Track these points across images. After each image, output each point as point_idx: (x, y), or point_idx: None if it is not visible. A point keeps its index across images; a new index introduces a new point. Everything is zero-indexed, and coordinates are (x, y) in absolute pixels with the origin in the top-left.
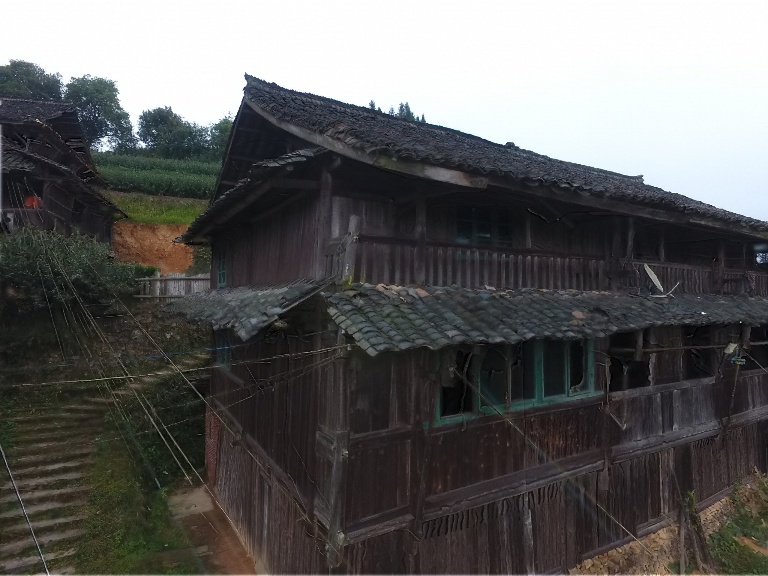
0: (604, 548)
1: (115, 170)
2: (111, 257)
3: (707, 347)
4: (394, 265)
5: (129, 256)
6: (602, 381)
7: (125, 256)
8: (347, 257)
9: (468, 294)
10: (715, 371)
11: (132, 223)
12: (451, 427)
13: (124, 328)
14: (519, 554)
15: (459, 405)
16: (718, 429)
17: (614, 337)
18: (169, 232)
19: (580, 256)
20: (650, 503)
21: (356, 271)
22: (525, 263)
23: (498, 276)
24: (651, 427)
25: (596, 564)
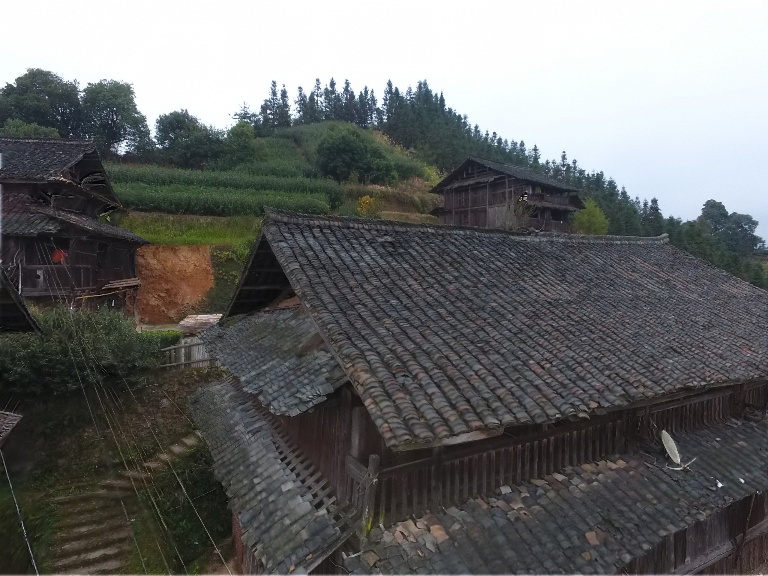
0: None
1: (135, 189)
2: (135, 285)
3: None
4: (412, 490)
5: (152, 278)
6: None
7: (148, 278)
8: (367, 499)
9: (484, 521)
10: None
11: (154, 245)
12: None
13: (152, 398)
14: None
15: None
16: (731, 550)
17: None
18: (190, 253)
19: (597, 424)
20: None
21: (376, 509)
22: (541, 445)
23: (514, 467)
24: (663, 567)
25: None
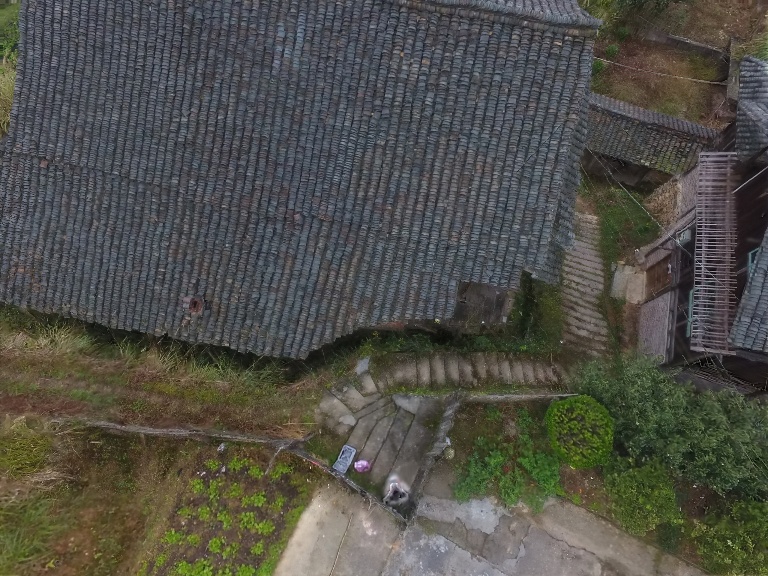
0: None
1: None
2: None
3: None
4: None
5: None
6: None
7: None
8: None
9: None
10: None
11: None
12: None
13: None
14: None
15: None
16: None
17: None
18: None
19: None
20: None
21: None
22: None
23: None
24: None
25: None
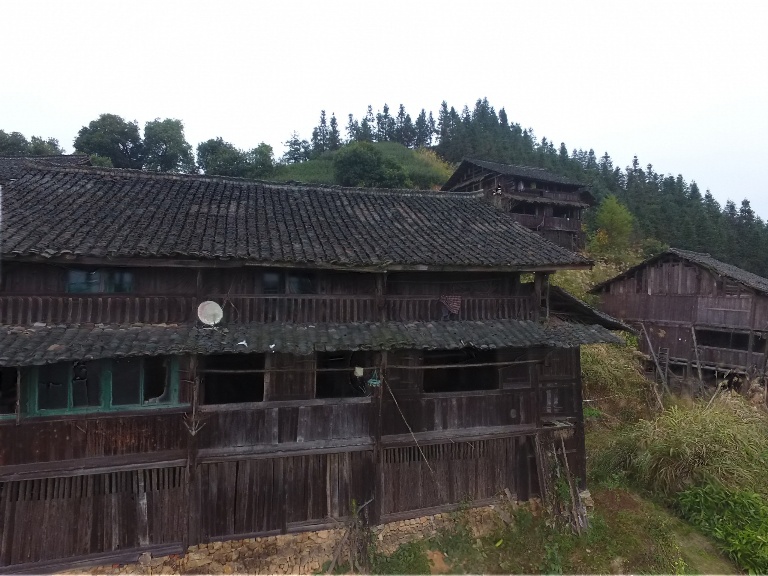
0: (240, 535)
1: None
2: None
3: (324, 370)
4: None
5: None
6: (190, 395)
7: None
8: None
9: None
10: (375, 391)
11: None
12: (2, 422)
13: None
14: (127, 525)
15: (13, 407)
16: (370, 445)
17: (200, 360)
18: None
19: (161, 295)
20: (311, 505)
21: None
22: (97, 303)
23: (64, 314)
24: (261, 437)
25: (224, 546)
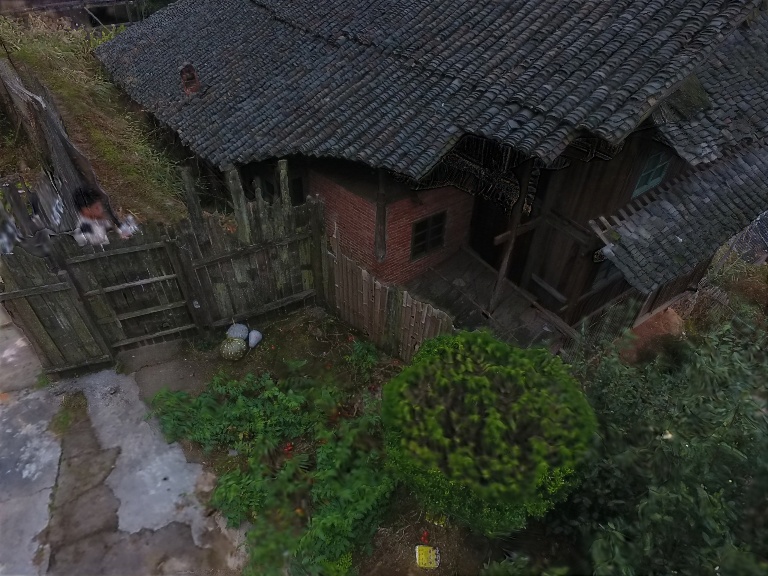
0: None
1: None
2: None
3: None
4: None
5: None
6: None
7: None
8: None
9: None
10: None
11: None
12: None
13: None
14: None
15: None
16: None
17: None
18: None
19: None
20: None
21: None
22: None
23: None
24: None
25: None
